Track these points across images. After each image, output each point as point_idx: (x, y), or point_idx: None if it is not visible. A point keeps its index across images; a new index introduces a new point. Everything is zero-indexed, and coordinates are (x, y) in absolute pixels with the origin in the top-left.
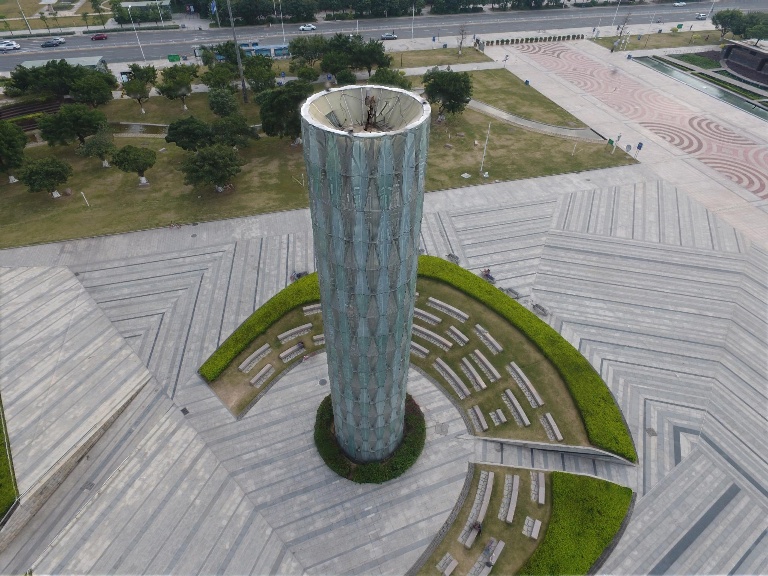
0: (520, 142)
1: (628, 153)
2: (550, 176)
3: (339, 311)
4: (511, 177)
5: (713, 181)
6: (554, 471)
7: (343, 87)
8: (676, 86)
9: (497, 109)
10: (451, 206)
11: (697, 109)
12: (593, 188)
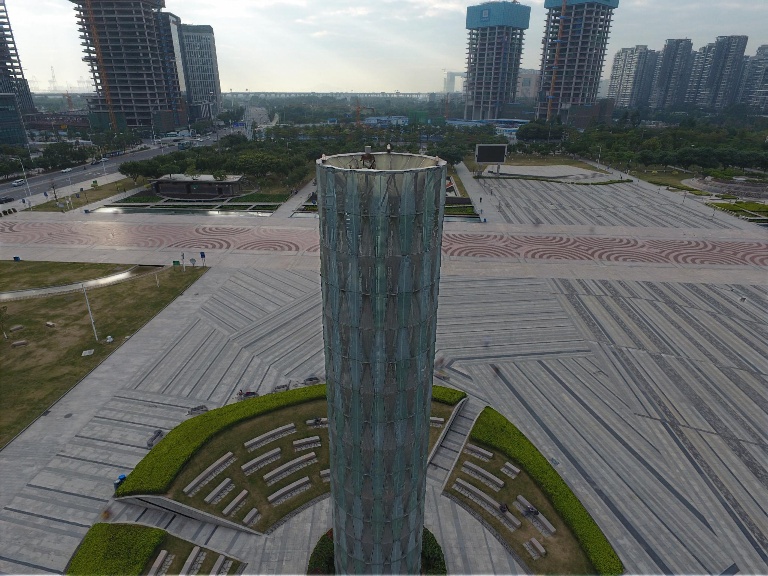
0: (96, 301)
1: (194, 265)
2: (166, 308)
3: (416, 386)
4: (135, 327)
5: (264, 255)
6: (470, 434)
7: (320, 160)
8: (154, 217)
9: (19, 291)
10: (118, 382)
11: (190, 225)
12: (209, 297)
